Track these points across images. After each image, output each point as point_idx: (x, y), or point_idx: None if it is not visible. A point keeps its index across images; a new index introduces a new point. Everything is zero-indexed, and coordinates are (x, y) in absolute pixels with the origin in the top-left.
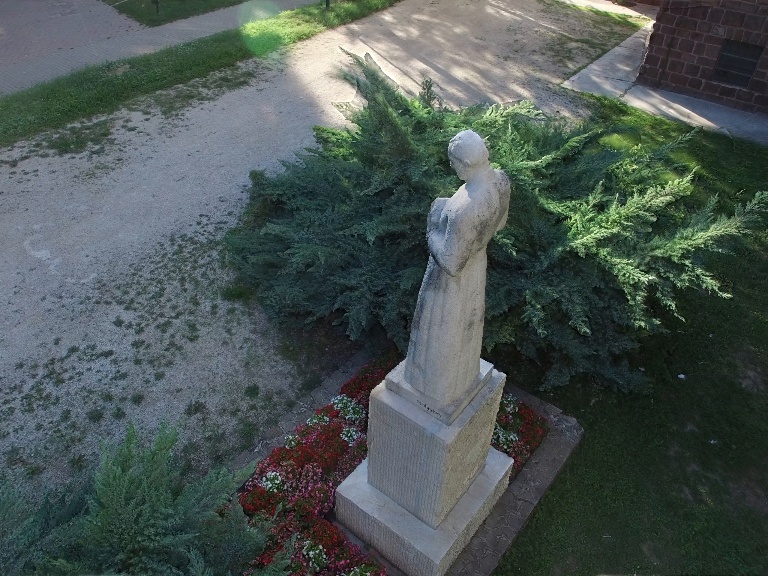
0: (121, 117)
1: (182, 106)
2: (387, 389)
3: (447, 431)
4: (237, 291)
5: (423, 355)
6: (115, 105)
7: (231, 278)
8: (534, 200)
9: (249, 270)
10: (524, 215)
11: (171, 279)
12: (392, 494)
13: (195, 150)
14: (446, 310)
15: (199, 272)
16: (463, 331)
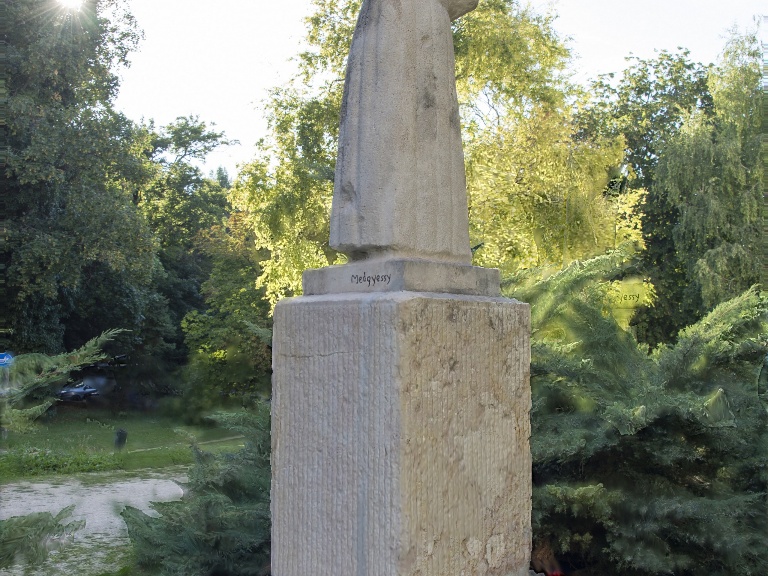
0: (16, 485)
1: (114, 481)
2: (305, 295)
3: (399, 292)
4: (120, 570)
5: (354, 159)
6: (13, 479)
7: (116, 569)
8: (625, 336)
9: (149, 533)
10: (610, 354)
11: (12, 568)
12: (315, 575)
13: (116, 501)
14: (381, 51)
15: (64, 564)
16: (415, 102)
